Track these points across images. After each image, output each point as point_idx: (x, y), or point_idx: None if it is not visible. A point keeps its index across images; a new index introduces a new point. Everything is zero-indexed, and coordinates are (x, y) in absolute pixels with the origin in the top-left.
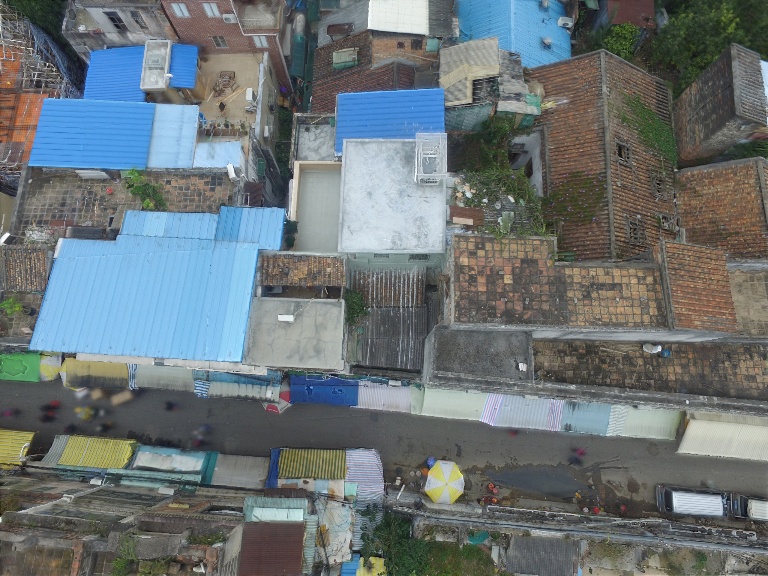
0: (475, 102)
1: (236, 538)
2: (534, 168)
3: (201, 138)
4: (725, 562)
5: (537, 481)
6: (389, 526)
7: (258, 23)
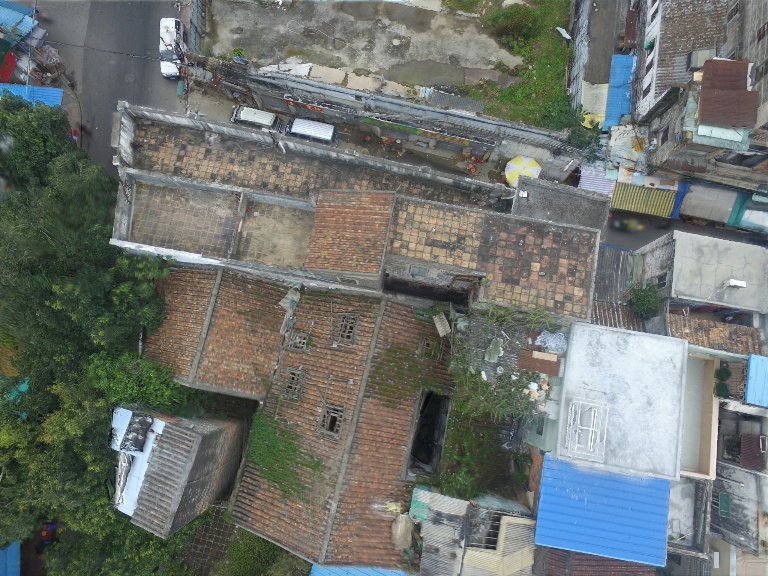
0: (499, 516)
1: None
2: None
3: None
4: None
5: None
6: None
7: None
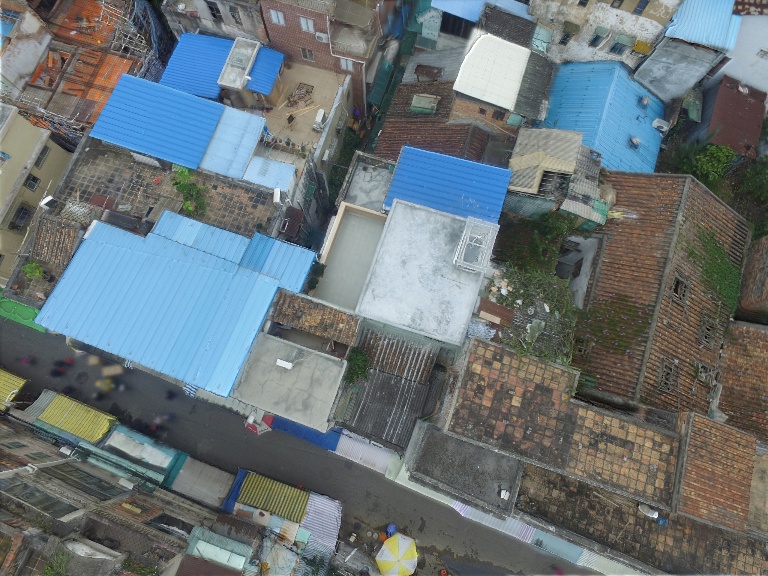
0: (540, 194)
1: (171, 571)
2: (582, 270)
3: (259, 152)
4: None
5: None
6: None
7: (349, 48)
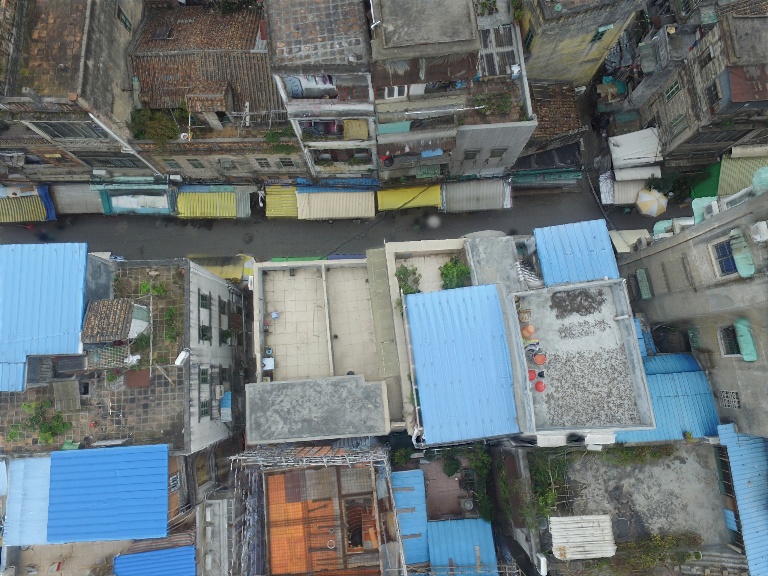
0: None
1: None
2: None
3: (3, 502)
4: None
5: None
6: None
7: None
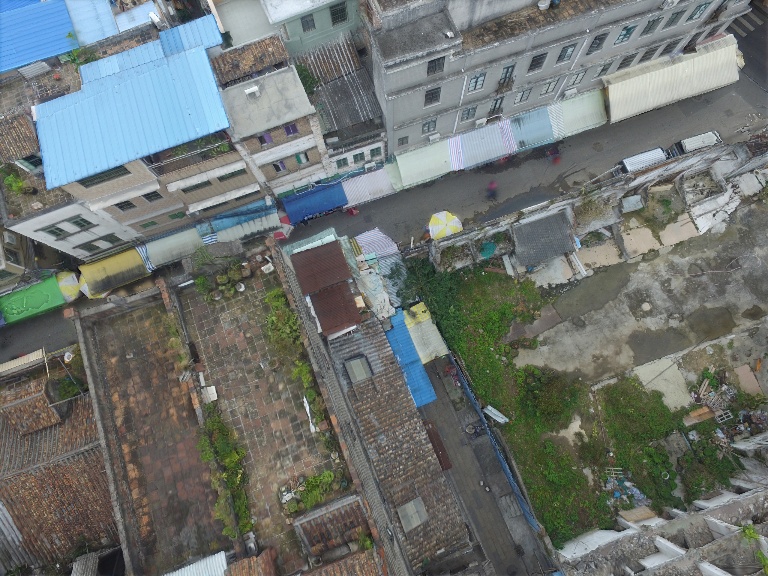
0: None
1: (287, 258)
2: None
3: (116, 11)
4: (685, 198)
5: (520, 209)
6: (415, 275)
7: None
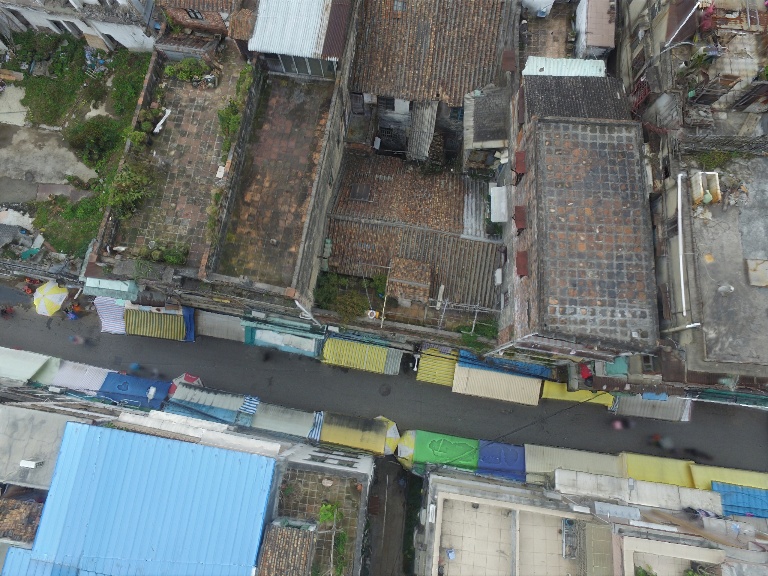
0: None
1: None
2: None
3: None
4: None
5: None
6: None
7: None
